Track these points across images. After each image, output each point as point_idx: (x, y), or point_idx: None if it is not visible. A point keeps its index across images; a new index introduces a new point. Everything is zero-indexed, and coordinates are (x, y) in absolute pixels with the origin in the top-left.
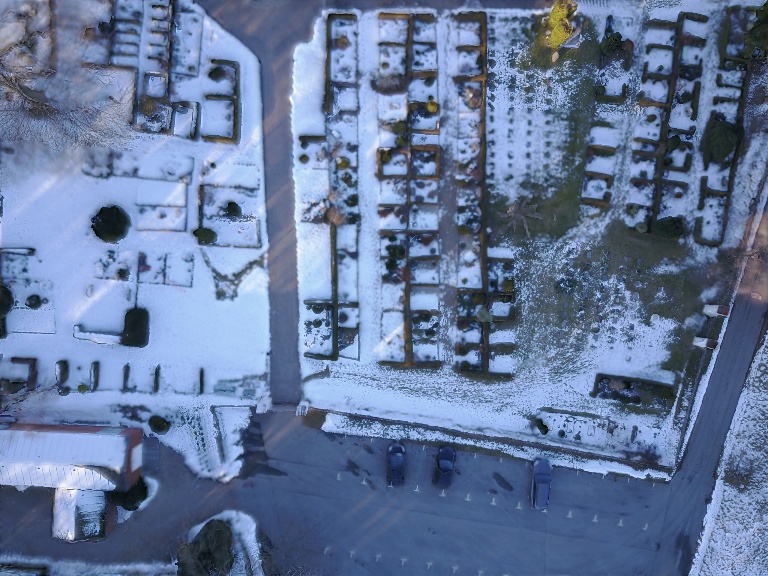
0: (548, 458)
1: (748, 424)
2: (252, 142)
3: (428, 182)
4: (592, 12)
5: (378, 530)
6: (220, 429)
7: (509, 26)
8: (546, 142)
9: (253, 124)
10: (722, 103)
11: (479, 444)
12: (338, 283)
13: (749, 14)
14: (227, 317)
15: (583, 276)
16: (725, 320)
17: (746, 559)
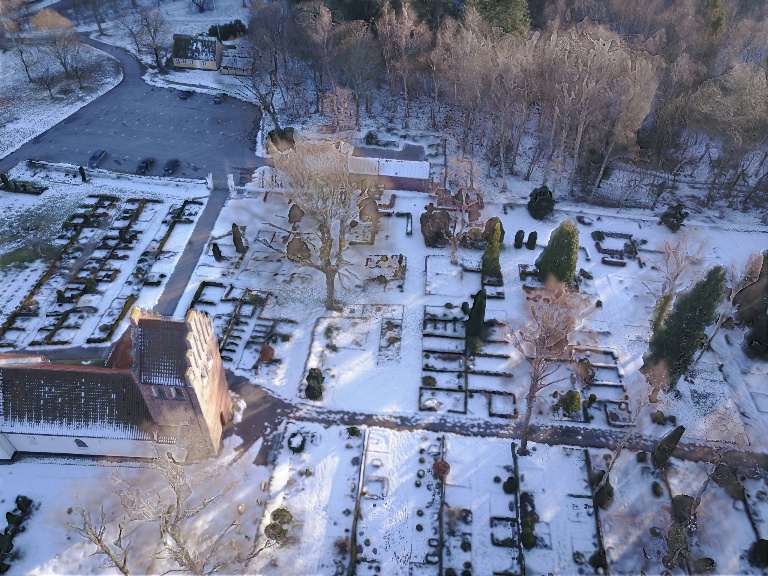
0: (88, 169)
1: None
2: (194, 286)
3: None
4: None
5: (192, 151)
6: None
7: None
8: None
9: (189, 293)
10: None
11: None
12: None
13: None
14: (243, 220)
15: (18, 232)
16: None
17: (8, 133)
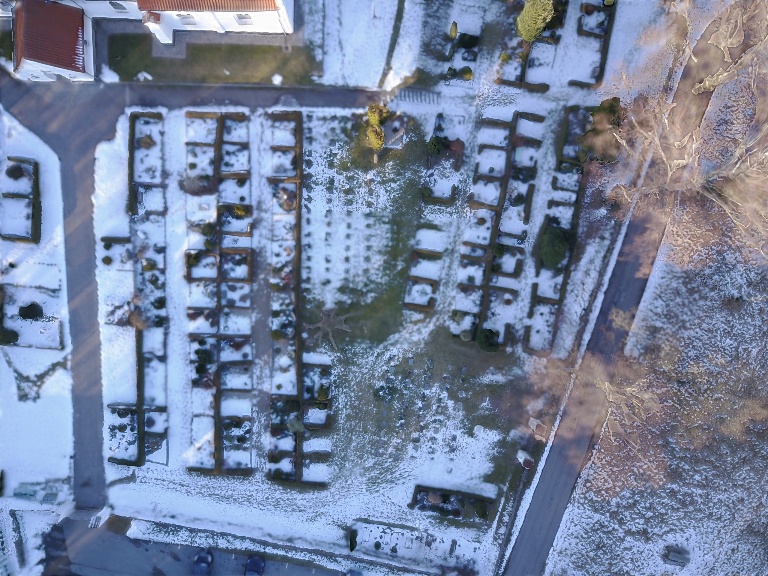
0: (362, 570)
1: (571, 542)
2: (53, 241)
3: (240, 285)
4: (417, 111)
5: None
6: (21, 533)
7: (327, 125)
8: (366, 246)
9: (53, 223)
10: (557, 207)
11: (291, 554)
12: (145, 387)
13: (588, 114)
14: (29, 418)
15: (404, 384)
16: (552, 433)
17: None
